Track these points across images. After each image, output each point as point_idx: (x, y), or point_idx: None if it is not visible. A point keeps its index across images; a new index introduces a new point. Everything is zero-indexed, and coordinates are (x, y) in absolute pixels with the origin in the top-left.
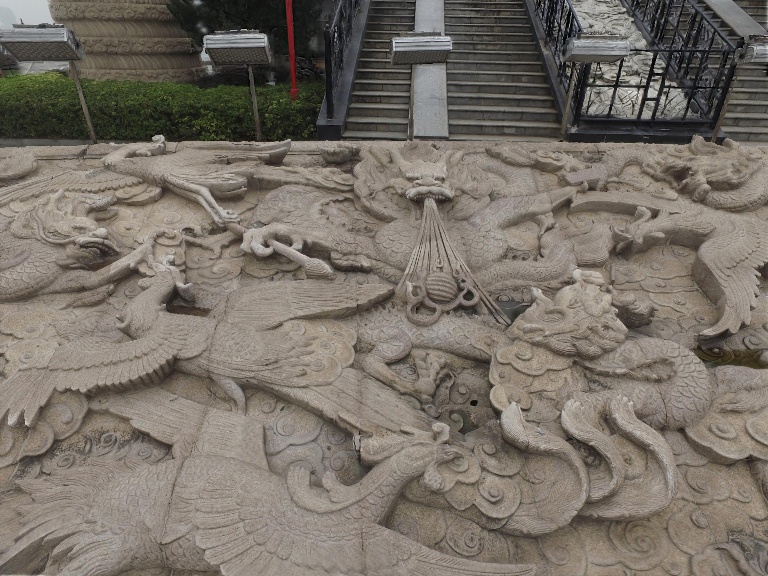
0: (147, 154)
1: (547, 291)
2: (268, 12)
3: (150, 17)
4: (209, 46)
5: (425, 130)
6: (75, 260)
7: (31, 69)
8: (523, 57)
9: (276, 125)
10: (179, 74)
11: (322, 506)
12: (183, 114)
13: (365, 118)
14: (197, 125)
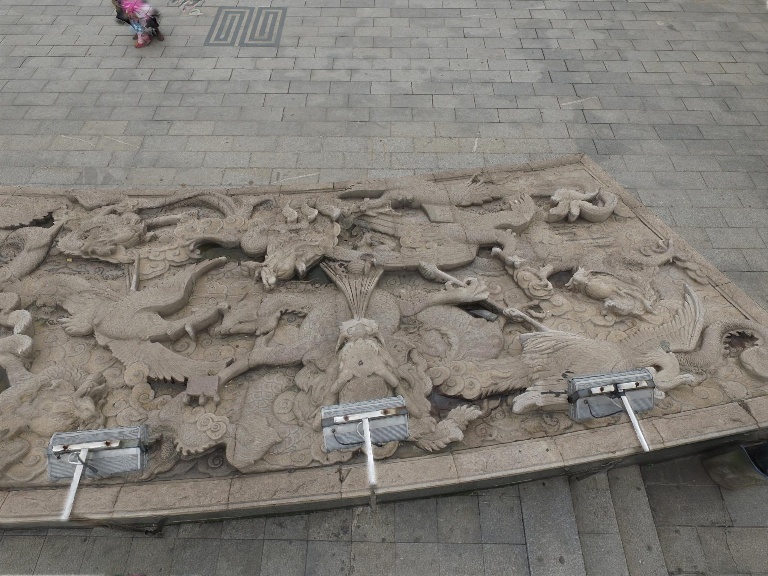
0: None
1: (290, 288)
2: None
3: None
4: None
5: None
6: None
7: None
8: None
9: None
10: None
11: (401, 191)
12: None
13: None
14: None
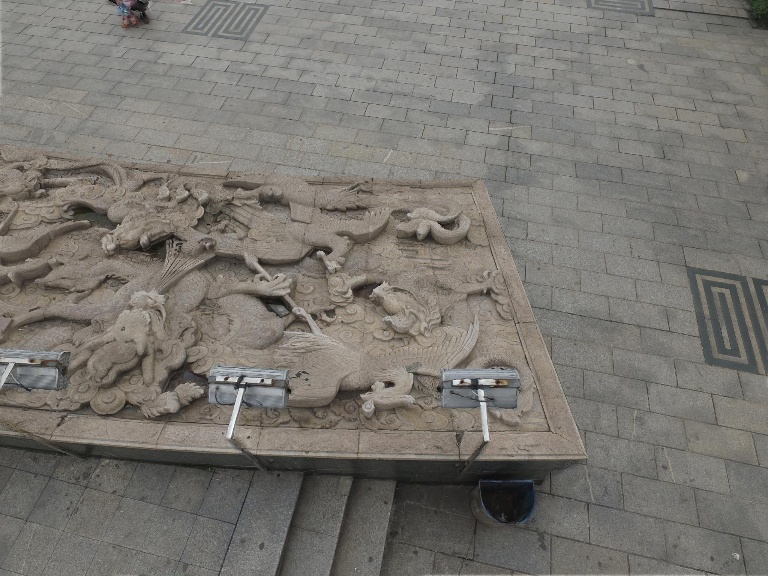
0: None
1: (129, 257)
2: None
3: None
4: None
5: None
6: None
7: None
8: None
9: None
10: None
11: (274, 187)
12: None
13: None
14: None
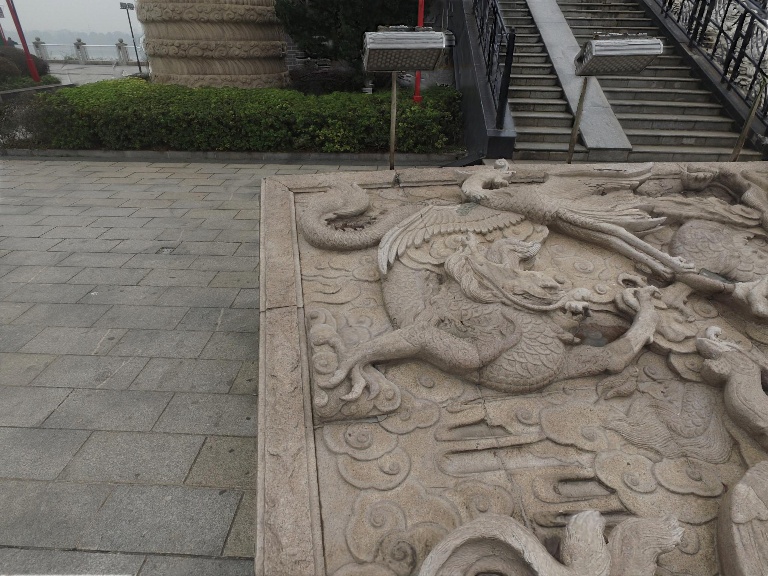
0: (506, 183)
1: None
2: (382, 14)
3: (248, 19)
4: (598, 53)
5: (605, 141)
6: (568, 332)
7: (111, 74)
8: (664, 61)
9: (407, 135)
10: (271, 79)
11: None
12: (307, 123)
13: (526, 128)
14: (321, 135)
